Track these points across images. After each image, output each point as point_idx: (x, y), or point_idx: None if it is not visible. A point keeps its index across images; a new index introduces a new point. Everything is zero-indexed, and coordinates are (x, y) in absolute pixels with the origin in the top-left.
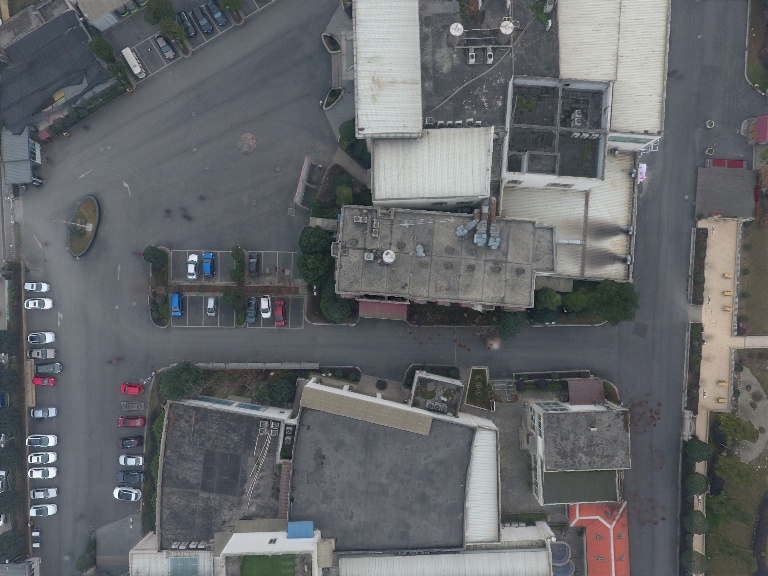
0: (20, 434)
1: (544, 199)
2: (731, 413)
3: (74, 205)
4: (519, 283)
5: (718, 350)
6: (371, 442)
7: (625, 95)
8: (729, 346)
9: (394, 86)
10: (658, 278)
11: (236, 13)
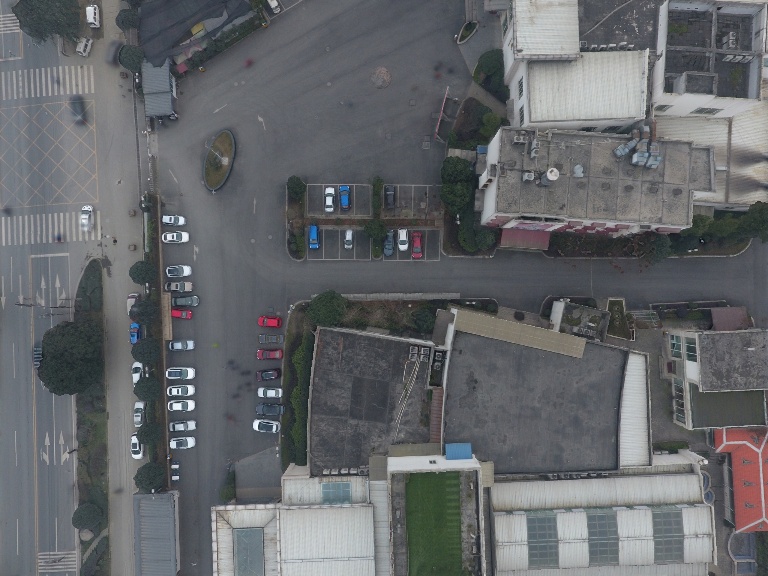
0: (159, 366)
1: (686, 127)
2: None
3: (209, 140)
4: (676, 203)
5: None
6: (523, 366)
7: None
8: None
9: (551, 8)
10: None
11: None
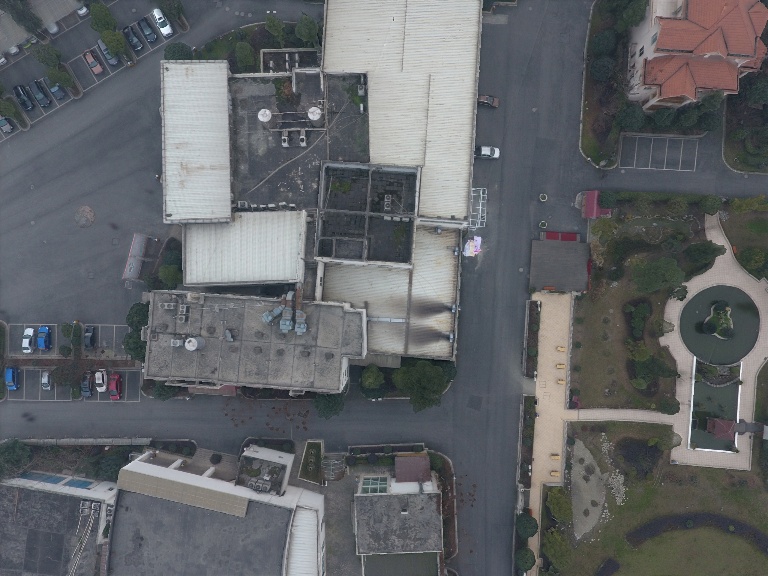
0: None
1: (370, 276)
2: (564, 486)
3: None
4: (328, 367)
5: (552, 423)
6: (189, 523)
7: (433, 180)
8: (563, 419)
9: (203, 172)
10: (493, 351)
11: (73, 87)
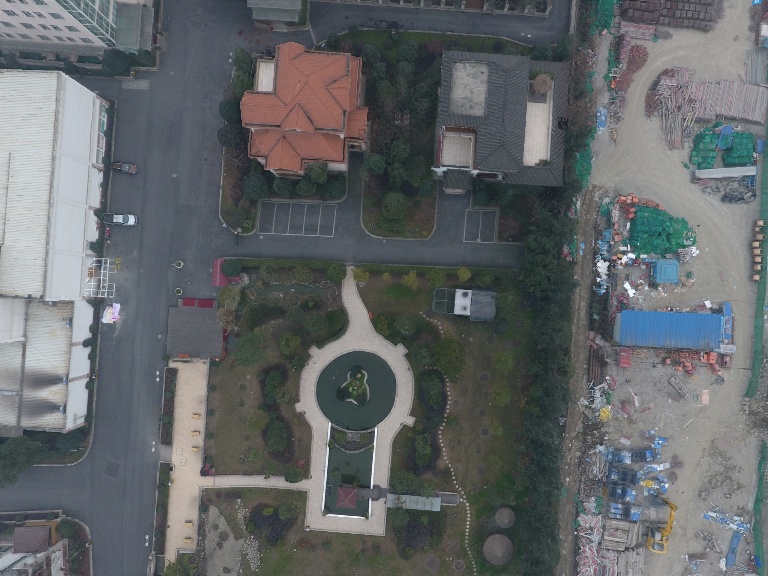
0: None
1: None
2: (197, 553)
3: None
4: None
5: (188, 489)
6: None
7: (11, 259)
8: (199, 485)
9: None
10: (131, 417)
11: None
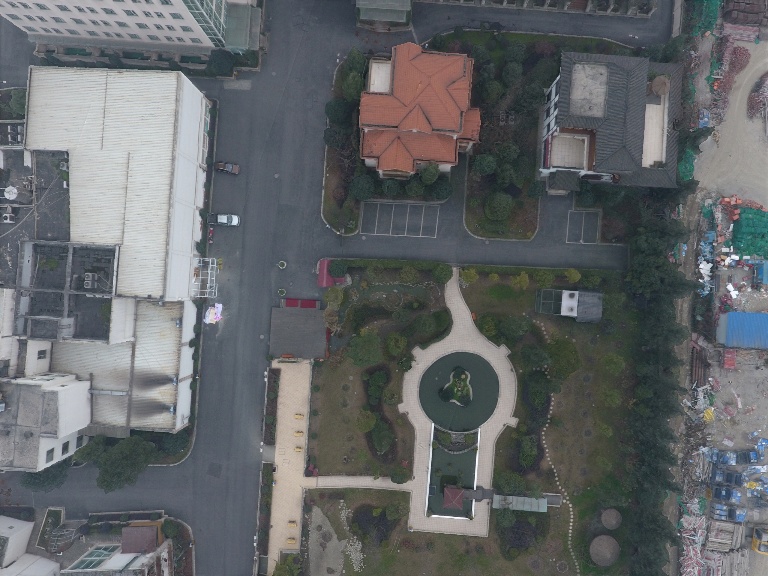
0: None
1: (95, 348)
2: (301, 553)
3: None
4: (28, 446)
5: (291, 490)
6: None
7: (130, 259)
8: (302, 486)
9: None
10: (233, 418)
11: None
